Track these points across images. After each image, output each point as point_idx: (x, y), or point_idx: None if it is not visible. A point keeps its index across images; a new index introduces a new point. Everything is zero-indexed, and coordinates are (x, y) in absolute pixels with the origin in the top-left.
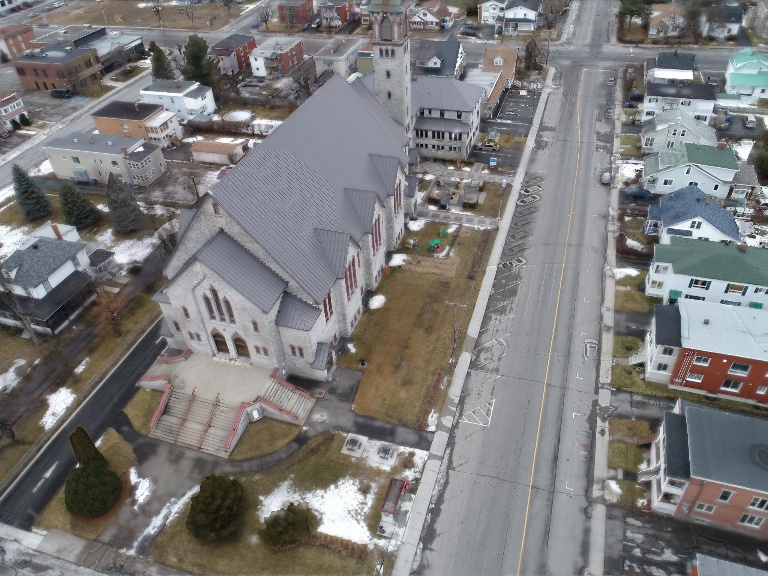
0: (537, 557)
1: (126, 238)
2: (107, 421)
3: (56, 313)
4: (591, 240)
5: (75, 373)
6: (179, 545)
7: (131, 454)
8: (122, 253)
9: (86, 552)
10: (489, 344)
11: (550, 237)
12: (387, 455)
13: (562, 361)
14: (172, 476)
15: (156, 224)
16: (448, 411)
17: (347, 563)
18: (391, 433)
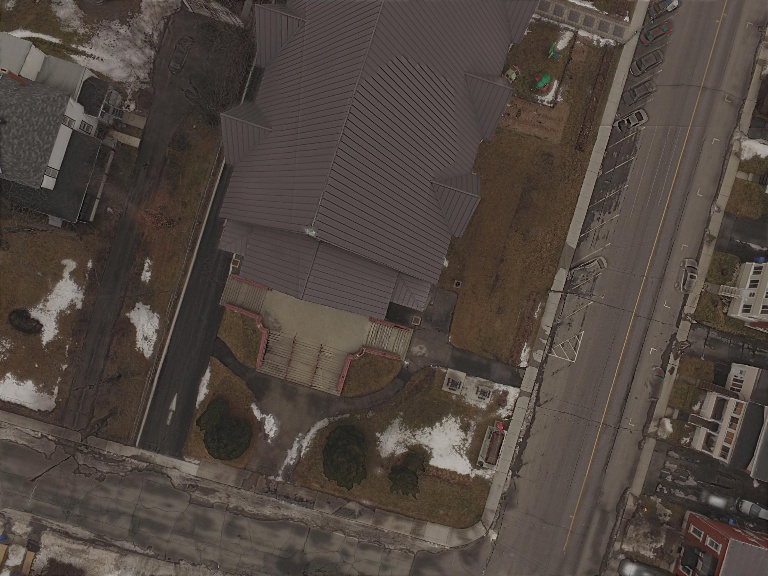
0: (596, 482)
1: (101, 16)
2: (206, 349)
3: (82, 205)
4: (732, 80)
5: (143, 283)
6: (318, 475)
7: (246, 390)
8: (110, 54)
9: (241, 479)
10: (591, 268)
11: (685, 70)
12: (485, 397)
13: (655, 285)
14: (293, 413)
15: None
16: (540, 345)
17: (455, 489)
18: (487, 369)
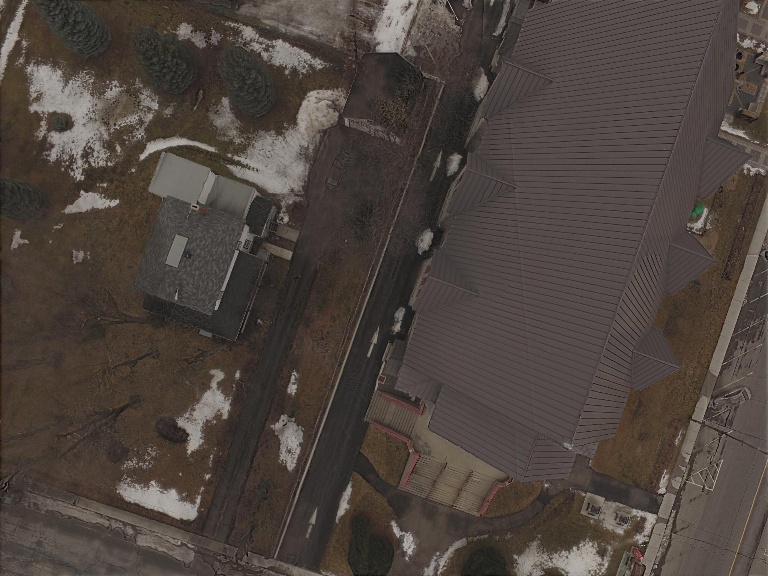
0: None
1: (258, 126)
2: (349, 464)
3: None
4: None
5: (290, 395)
6: None
7: (387, 507)
8: (265, 165)
9: None
10: (736, 400)
11: None
12: None
13: None
14: (432, 531)
15: (292, 94)
16: (679, 472)
17: None
18: (626, 495)
